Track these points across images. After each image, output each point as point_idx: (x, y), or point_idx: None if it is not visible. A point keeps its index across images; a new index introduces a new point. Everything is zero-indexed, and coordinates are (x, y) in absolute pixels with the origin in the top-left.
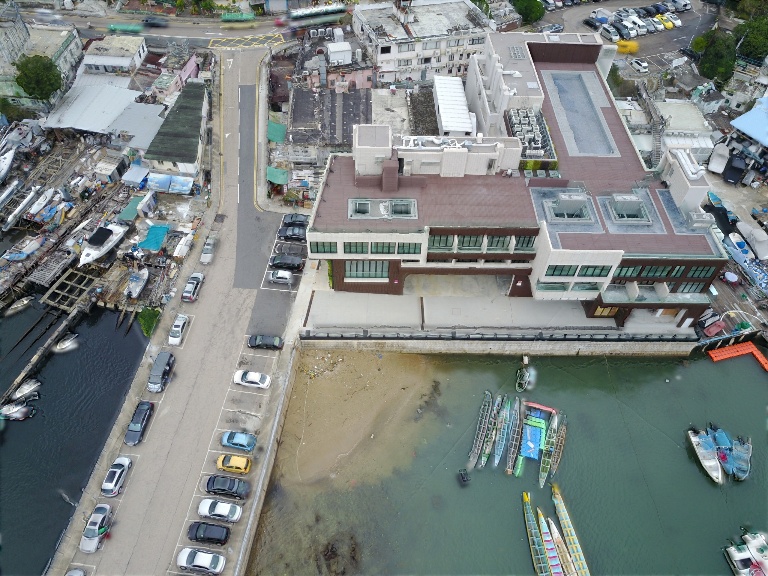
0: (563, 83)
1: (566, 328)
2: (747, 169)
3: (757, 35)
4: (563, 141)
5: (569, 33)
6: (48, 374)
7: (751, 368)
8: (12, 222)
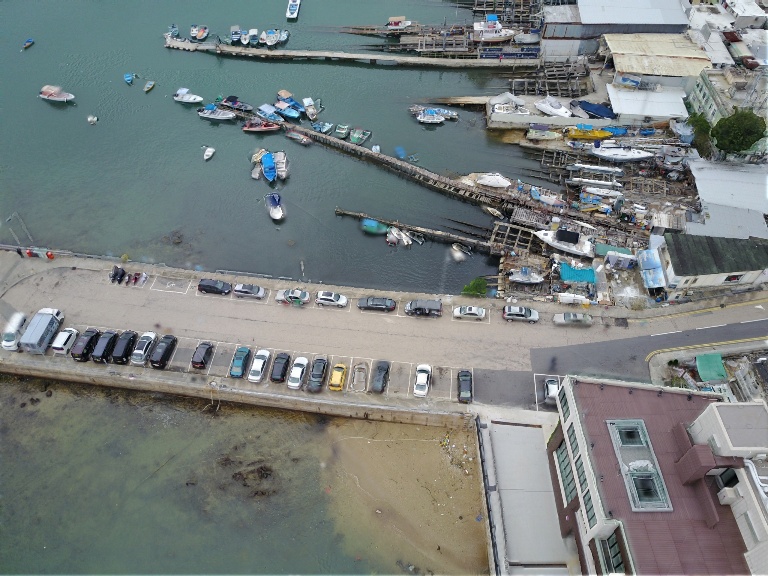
0: None
1: None
2: None
3: None
4: None
5: None
6: (434, 248)
7: None
8: (575, 182)
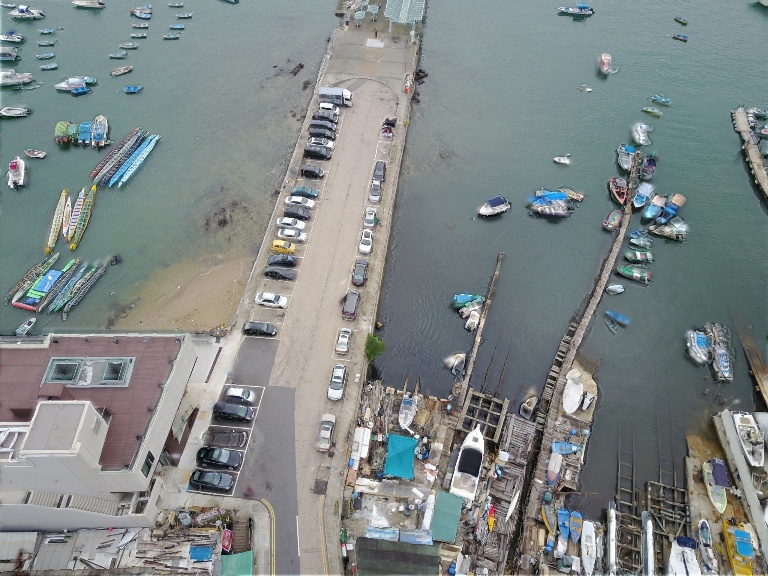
0: None
1: None
2: None
3: None
4: None
5: None
6: None
7: None
8: None
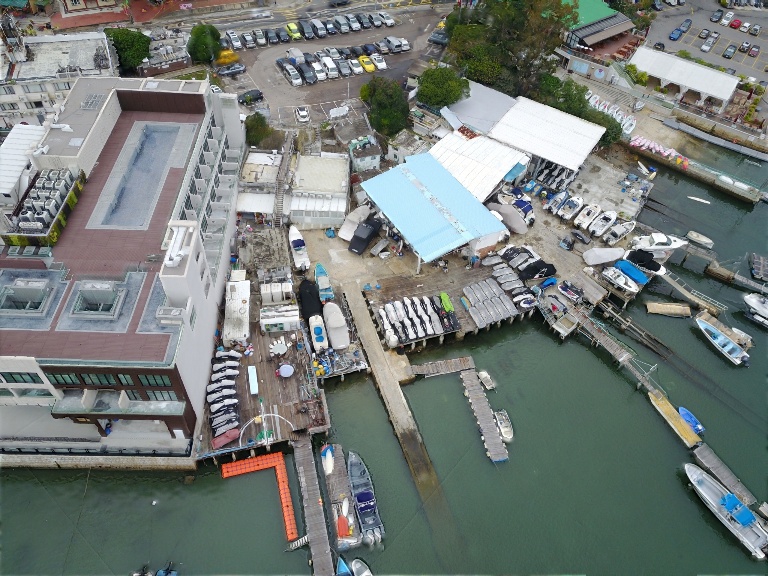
0: (159, 136)
1: (27, 439)
2: (385, 236)
3: (429, 84)
4: (92, 209)
5: None
6: None
7: (269, 486)
8: None
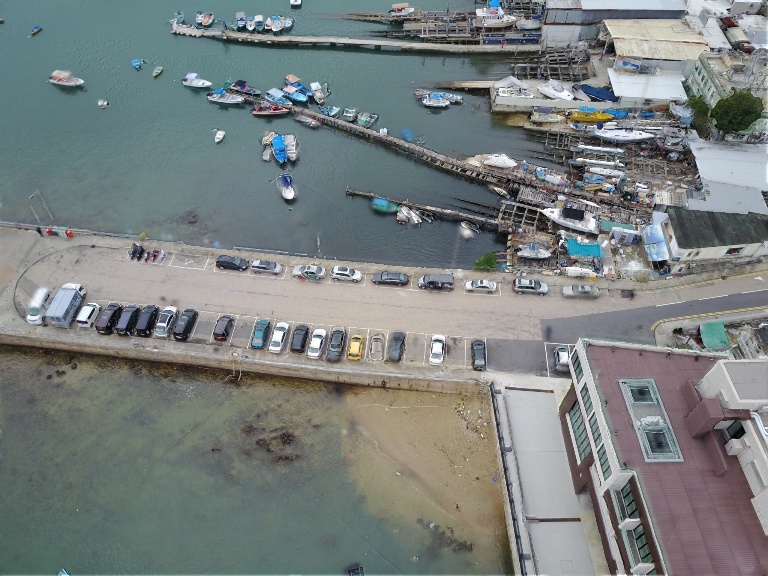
0: None
1: None
2: None
3: None
4: None
5: None
6: (443, 227)
7: None
8: (578, 163)
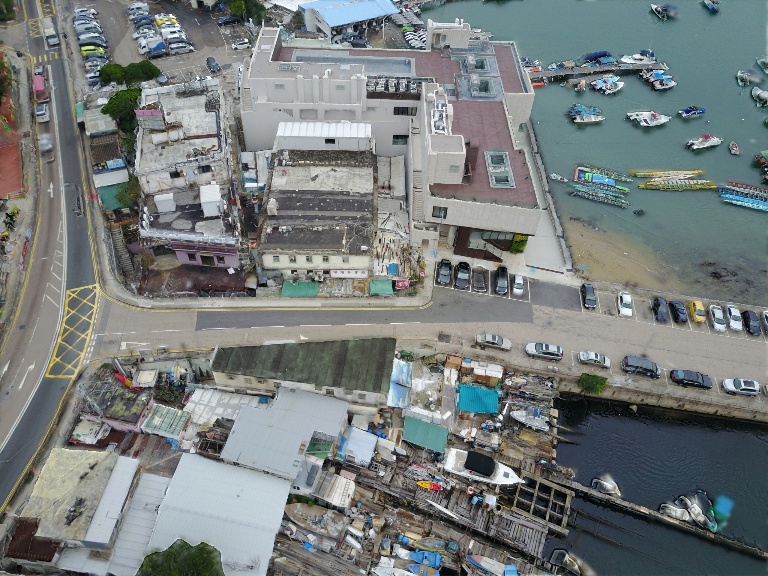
0: None
1: None
2: None
3: None
4: None
5: (258, 40)
6: None
7: None
8: None
